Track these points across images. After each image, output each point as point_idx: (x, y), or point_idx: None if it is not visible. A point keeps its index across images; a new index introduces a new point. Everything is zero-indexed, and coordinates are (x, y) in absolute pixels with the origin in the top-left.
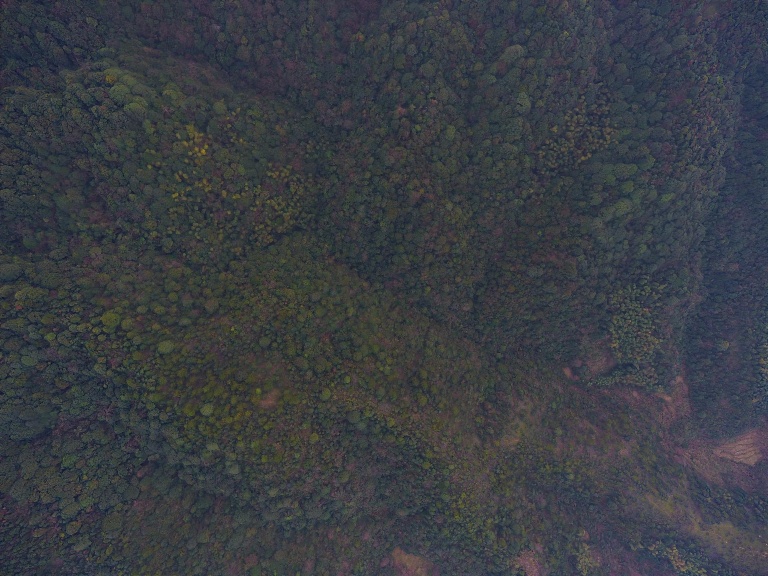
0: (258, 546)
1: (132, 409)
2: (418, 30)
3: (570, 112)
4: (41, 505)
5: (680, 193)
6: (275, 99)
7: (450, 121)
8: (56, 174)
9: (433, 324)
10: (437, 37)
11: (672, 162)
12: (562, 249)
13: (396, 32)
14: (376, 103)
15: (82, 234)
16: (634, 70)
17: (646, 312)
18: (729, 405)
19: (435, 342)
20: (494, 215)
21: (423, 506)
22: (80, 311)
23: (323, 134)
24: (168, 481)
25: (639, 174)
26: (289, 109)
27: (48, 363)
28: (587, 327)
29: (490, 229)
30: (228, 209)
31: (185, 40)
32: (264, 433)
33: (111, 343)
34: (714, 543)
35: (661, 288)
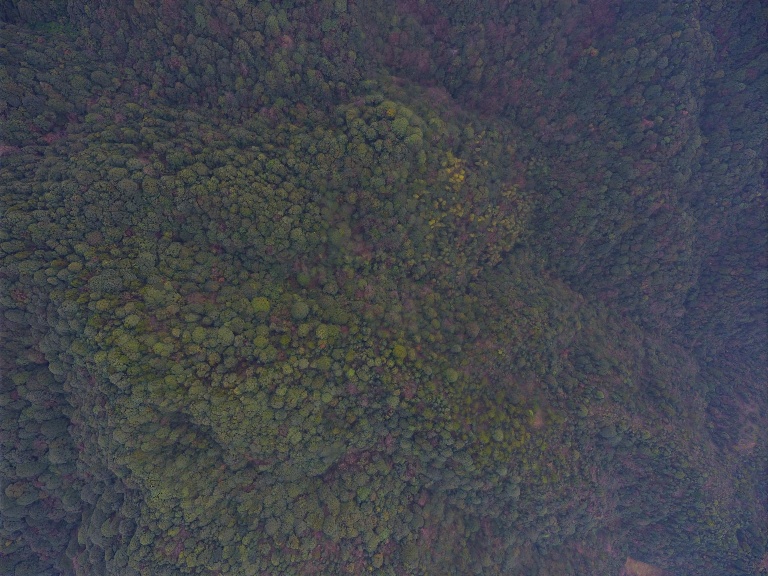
0: (522, 565)
1: (422, 439)
2: (673, 42)
3: None
4: (346, 540)
5: None
6: (497, 118)
7: None
8: (330, 209)
9: (644, 332)
10: (692, 48)
11: None
12: None
13: (645, 45)
14: (609, 117)
15: (345, 267)
16: None
17: None
18: None
19: (655, 350)
20: (718, 220)
21: (668, 515)
22: (373, 345)
23: (541, 150)
24: None
25: None
26: (513, 127)
27: (339, 398)
28: None
29: (707, 234)
30: (470, 232)
31: (422, 66)
32: (540, 454)
33: (402, 375)
34: None
35: None
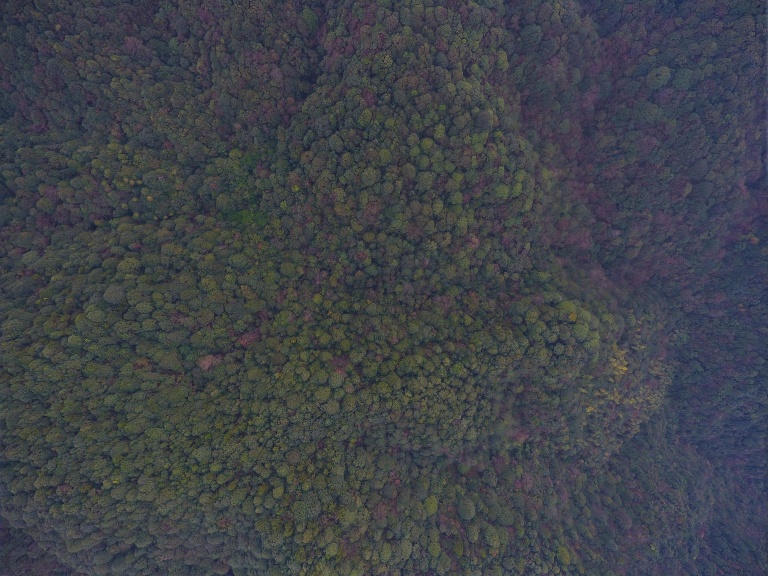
0: None
1: None
2: None
3: None
4: None
5: None
6: (643, 289)
7: None
8: (498, 402)
9: (766, 498)
10: None
11: None
12: None
13: None
14: (763, 302)
15: (501, 451)
16: None
17: None
18: None
19: None
20: None
21: None
22: (539, 550)
23: (684, 320)
24: None
25: None
26: (660, 301)
27: None
28: None
29: None
30: (619, 411)
31: None
32: None
33: None
34: None
35: None
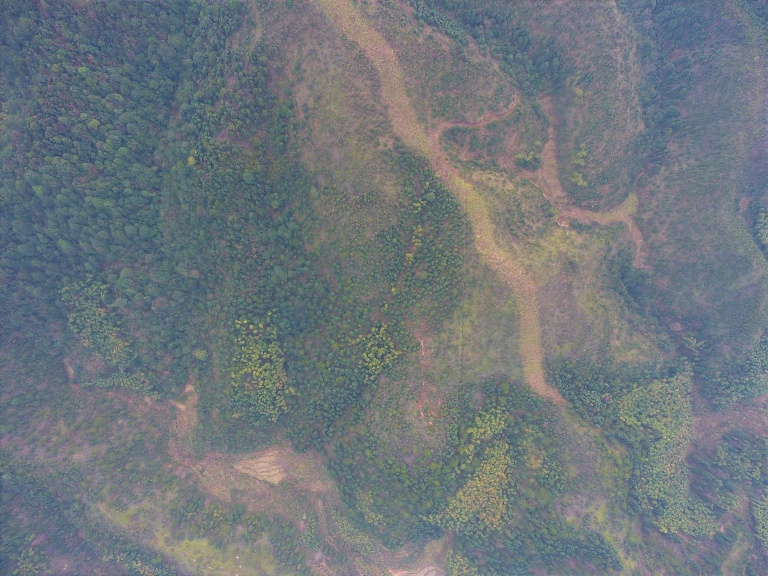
0: None
1: None
2: None
3: None
4: None
5: (51, 186)
6: None
7: None
8: None
9: None
10: None
11: (24, 152)
12: None
13: None
14: None
15: None
16: None
17: (101, 312)
18: None
19: None
20: None
21: None
22: None
23: None
24: None
25: (4, 162)
26: None
27: None
28: (56, 323)
29: None
30: None
31: None
32: None
33: None
34: (181, 560)
35: None
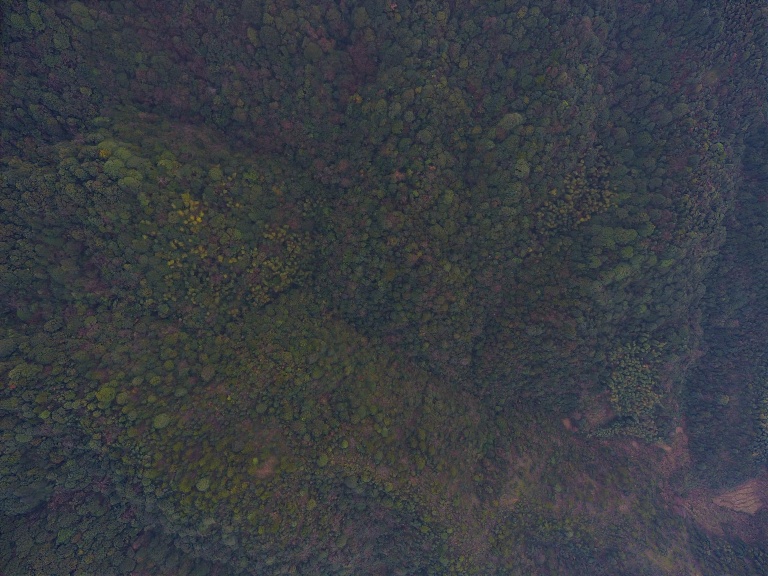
0: None
1: (128, 483)
2: (416, 97)
3: (569, 176)
4: None
5: (680, 259)
6: (272, 158)
7: (448, 184)
8: (50, 246)
9: (431, 378)
10: (435, 104)
11: (672, 230)
12: (561, 310)
13: (393, 98)
14: (373, 164)
15: (77, 303)
16: (634, 134)
17: (646, 369)
18: (729, 458)
19: (433, 398)
20: (493, 273)
21: (421, 567)
22: (75, 387)
23: (320, 191)
24: (164, 550)
25: (639, 240)
26: (286, 168)
27: (43, 438)
28: (586, 382)
29: (489, 285)
30: (224, 272)
31: (180, 103)
32: (261, 503)
33: (106, 418)
34: None
35: (661, 346)
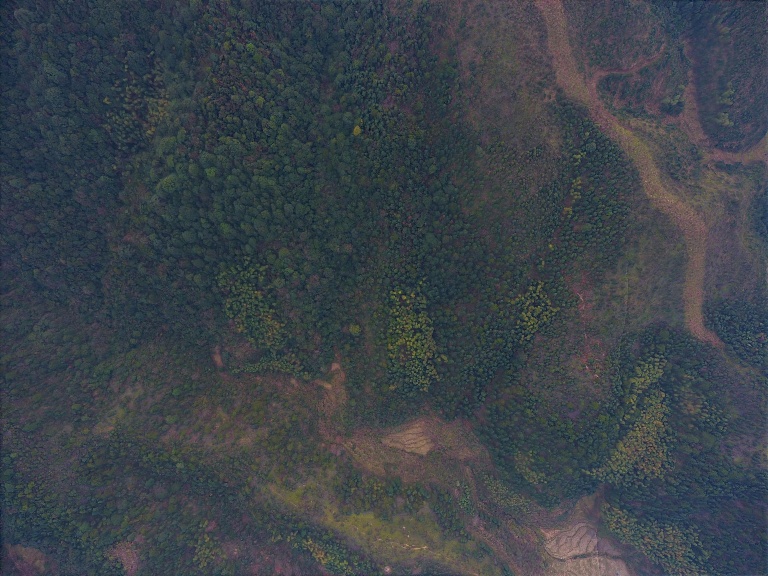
0: None
1: None
2: None
3: (117, 82)
4: None
5: (224, 167)
6: None
7: None
8: None
9: (59, 308)
10: None
11: (199, 134)
12: (139, 228)
13: None
14: None
15: None
16: None
17: (257, 295)
18: (373, 392)
19: (45, 326)
20: (85, 193)
21: None
22: None
23: None
24: None
25: (176, 147)
26: None
27: None
28: (209, 311)
29: (95, 208)
30: None
31: None
32: None
33: None
34: (351, 534)
35: (261, 269)
